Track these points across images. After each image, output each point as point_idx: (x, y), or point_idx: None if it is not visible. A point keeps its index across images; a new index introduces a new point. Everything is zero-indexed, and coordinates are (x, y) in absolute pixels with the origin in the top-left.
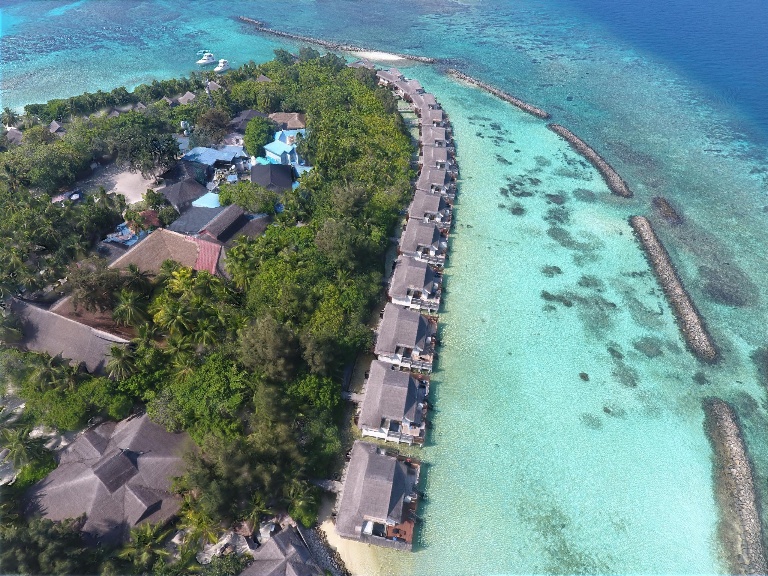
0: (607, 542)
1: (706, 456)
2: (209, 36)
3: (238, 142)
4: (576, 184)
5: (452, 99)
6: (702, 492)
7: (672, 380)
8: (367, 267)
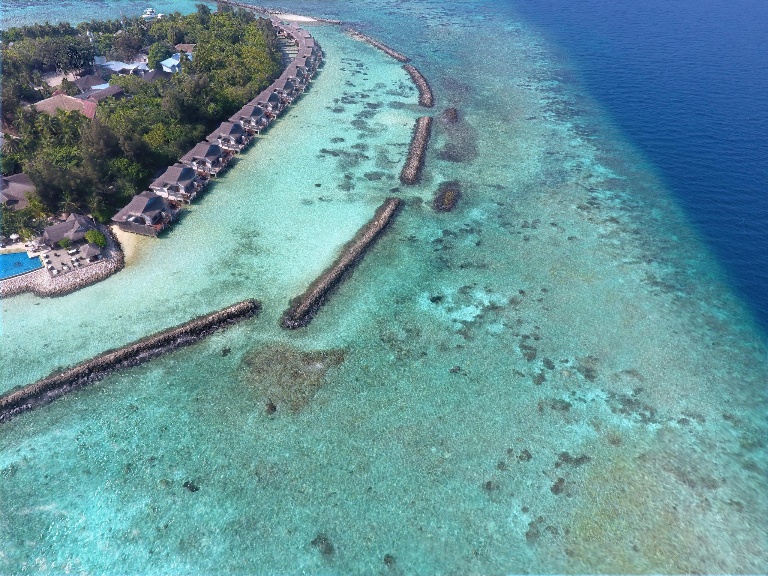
0: (276, 243)
1: (367, 219)
2: (161, 0)
3: (145, 61)
4: (395, 99)
5: (338, 47)
6: (351, 230)
7: (376, 190)
8: (195, 122)
